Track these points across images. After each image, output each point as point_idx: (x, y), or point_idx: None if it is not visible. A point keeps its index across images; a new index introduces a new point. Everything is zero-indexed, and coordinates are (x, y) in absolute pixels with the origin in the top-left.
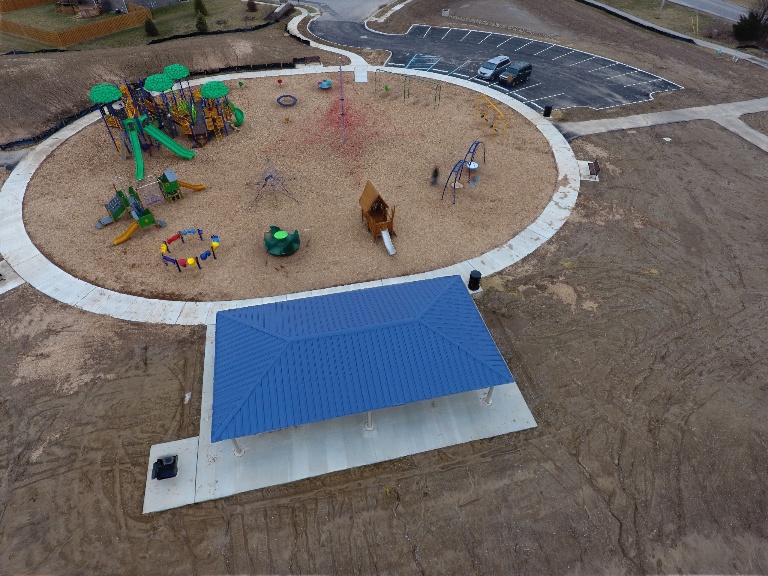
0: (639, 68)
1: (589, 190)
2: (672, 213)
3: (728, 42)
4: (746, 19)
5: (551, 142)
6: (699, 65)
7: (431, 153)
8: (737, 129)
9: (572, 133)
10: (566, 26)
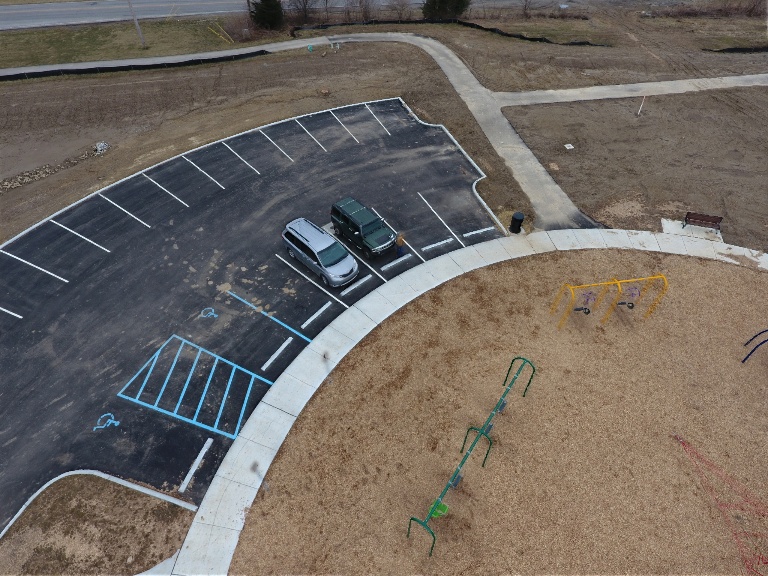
0: (322, 109)
1: (752, 242)
2: (767, 192)
3: (272, 36)
4: (260, 4)
5: (616, 246)
6: (329, 70)
7: (759, 433)
8: (524, 100)
9: (576, 217)
10: (70, 125)
